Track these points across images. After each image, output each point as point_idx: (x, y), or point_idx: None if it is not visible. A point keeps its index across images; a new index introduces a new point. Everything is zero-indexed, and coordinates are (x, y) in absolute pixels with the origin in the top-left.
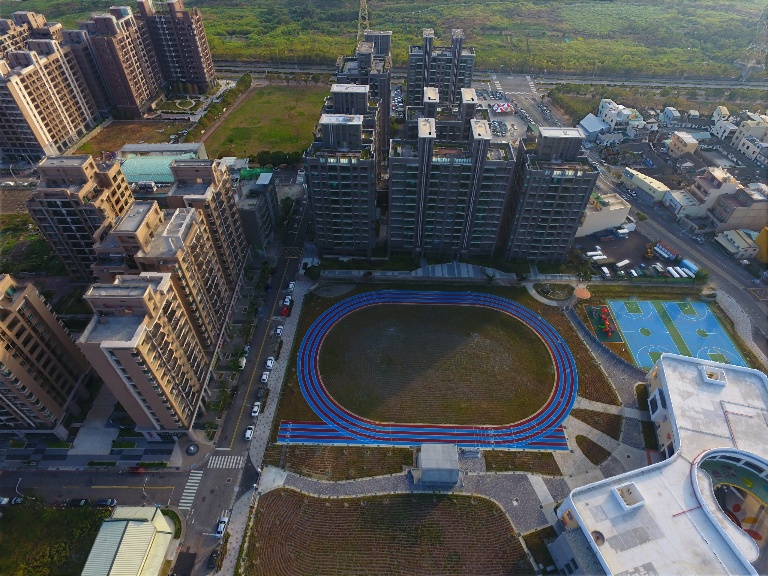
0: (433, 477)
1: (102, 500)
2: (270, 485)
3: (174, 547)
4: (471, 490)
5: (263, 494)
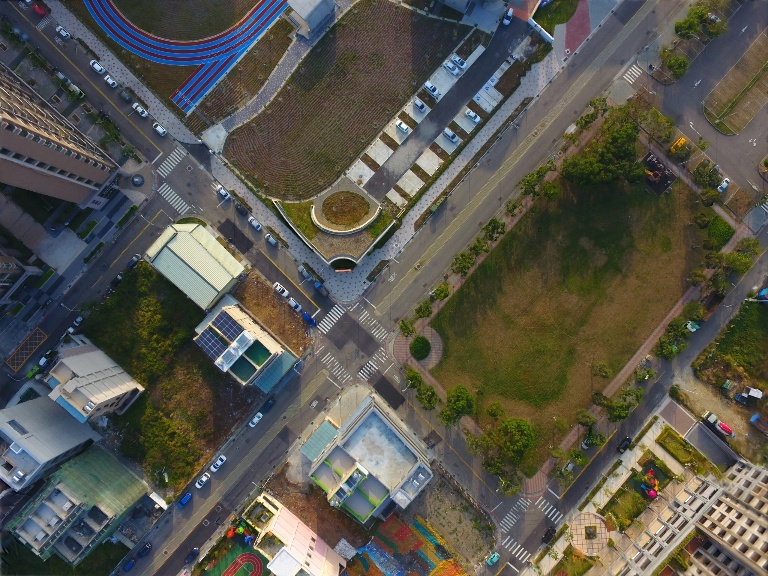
0: (317, 19)
1: (129, 263)
2: (219, 142)
3: (210, 230)
4: (347, 4)
5: (222, 151)
